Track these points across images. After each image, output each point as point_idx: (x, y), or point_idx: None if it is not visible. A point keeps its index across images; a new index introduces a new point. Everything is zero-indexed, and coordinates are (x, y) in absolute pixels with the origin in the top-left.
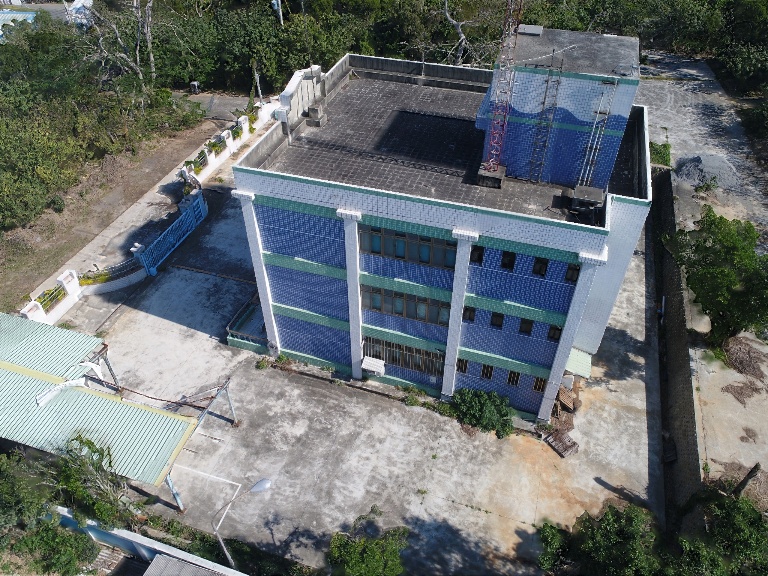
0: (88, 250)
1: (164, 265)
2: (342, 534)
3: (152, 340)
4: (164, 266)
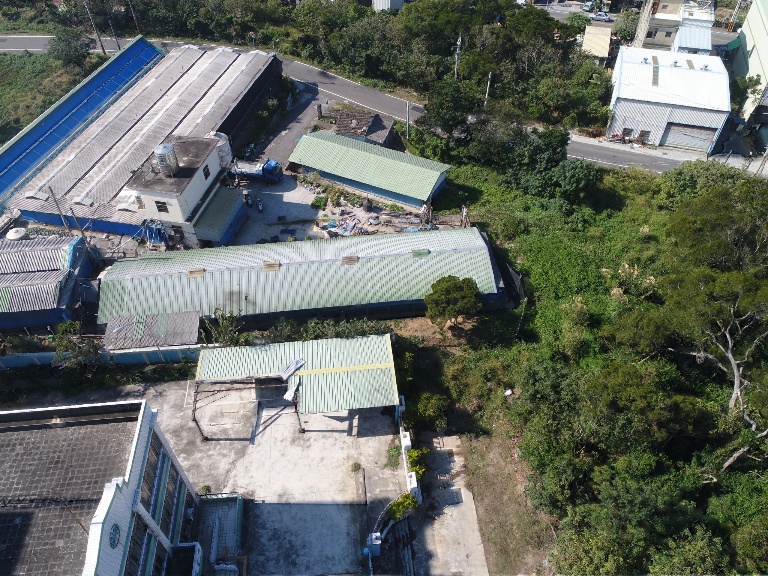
0: (480, 574)
1: (367, 570)
2: (83, 344)
3: (311, 479)
4: (365, 568)
